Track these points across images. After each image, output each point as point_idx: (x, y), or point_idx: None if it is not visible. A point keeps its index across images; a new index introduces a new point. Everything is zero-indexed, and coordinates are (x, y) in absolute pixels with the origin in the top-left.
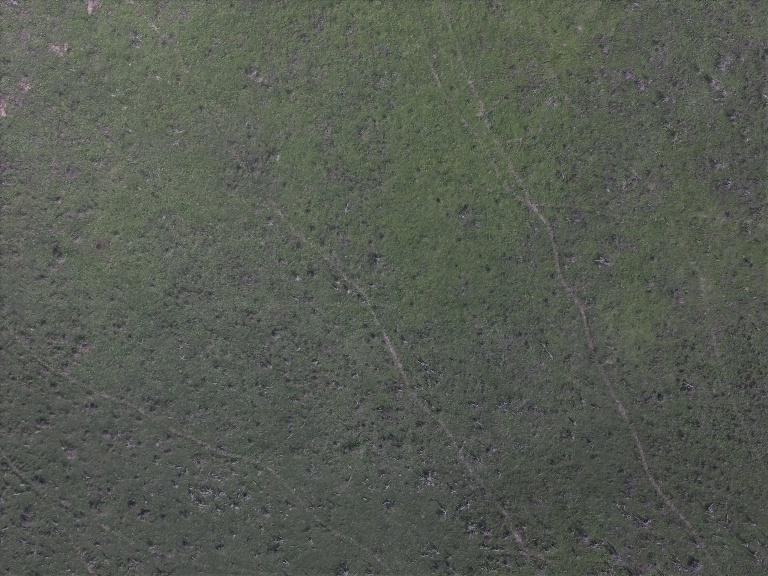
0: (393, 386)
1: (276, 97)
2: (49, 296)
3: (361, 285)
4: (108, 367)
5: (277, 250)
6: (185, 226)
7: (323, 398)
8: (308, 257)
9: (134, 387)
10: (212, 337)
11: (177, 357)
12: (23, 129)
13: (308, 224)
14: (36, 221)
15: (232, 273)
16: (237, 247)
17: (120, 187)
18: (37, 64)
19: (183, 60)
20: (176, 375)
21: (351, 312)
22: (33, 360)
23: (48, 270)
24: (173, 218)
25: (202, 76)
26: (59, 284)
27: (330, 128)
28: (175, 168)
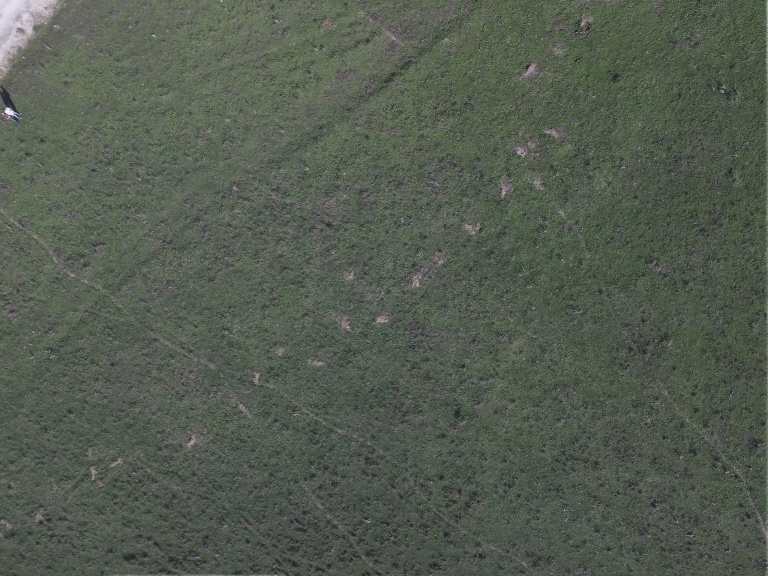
0: (763, 564)
1: (672, 286)
2: (448, 453)
3: (739, 467)
4: (497, 522)
5: (661, 428)
6: (577, 399)
7: (695, 569)
8: (690, 436)
9: (519, 542)
10: (595, 503)
11: (561, 518)
12: (435, 300)
13: (692, 406)
14: (441, 385)
15: (617, 446)
16: (623, 422)
17: (520, 359)
18: (450, 240)
19: (586, 245)
20: (558, 535)
21: (728, 491)
22: (430, 510)
23: (449, 430)
24: (567, 391)
25: (603, 261)
26: (458, 443)
27: (721, 318)
28: (572, 345)
